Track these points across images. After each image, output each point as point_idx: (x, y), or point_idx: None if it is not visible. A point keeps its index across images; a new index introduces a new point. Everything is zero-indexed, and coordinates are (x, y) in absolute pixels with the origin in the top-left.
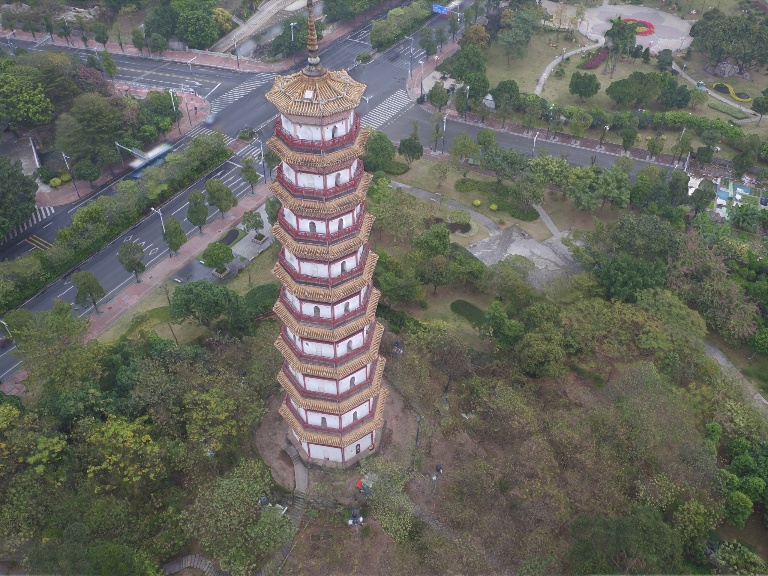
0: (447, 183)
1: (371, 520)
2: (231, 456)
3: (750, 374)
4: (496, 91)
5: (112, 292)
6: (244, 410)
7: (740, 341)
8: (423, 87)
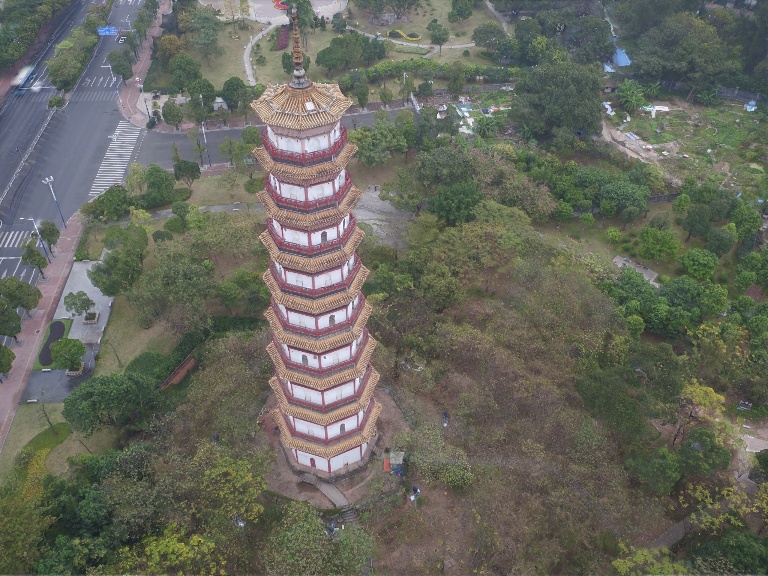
0: (237, 190)
1: None
2: (259, 516)
3: None
4: (224, 92)
5: None
6: None
7: (548, 217)
8: (142, 112)
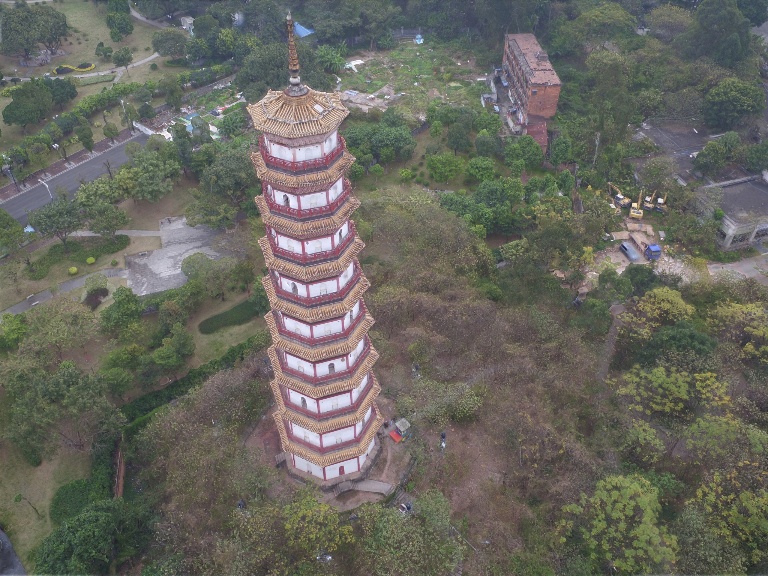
0: None
1: (429, 443)
2: None
3: None
4: None
5: None
6: None
7: None
8: None
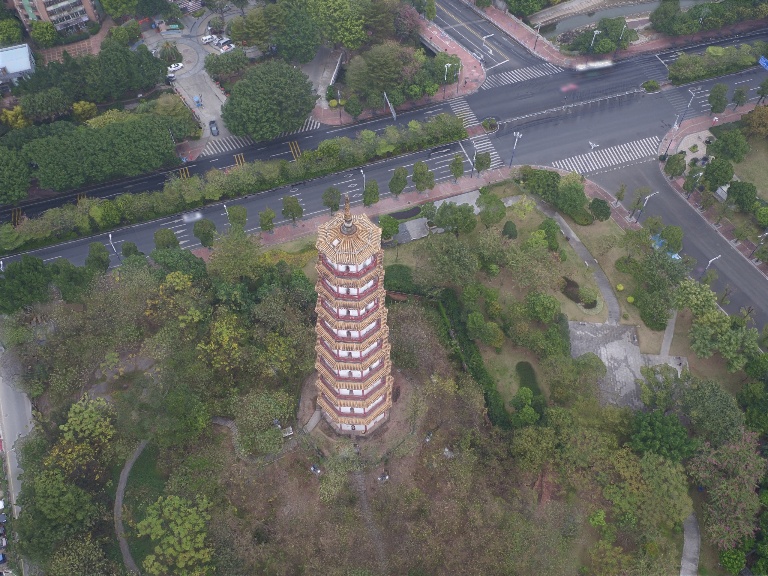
0: (613, 254)
1: None
2: (285, 381)
3: (704, 575)
4: (732, 187)
5: (312, 214)
6: (304, 360)
7: (717, 546)
8: (680, 143)
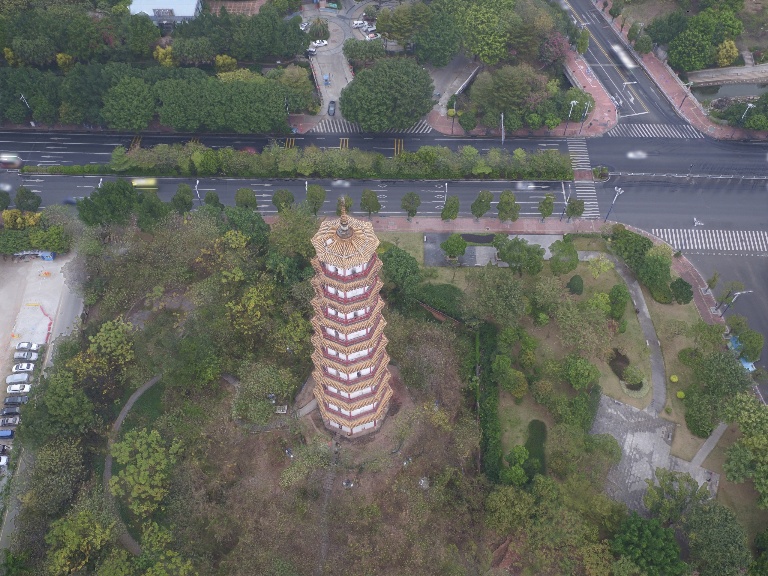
0: (680, 342)
1: None
2: (297, 361)
3: None
4: None
5: (390, 213)
6: None
7: None
8: None
